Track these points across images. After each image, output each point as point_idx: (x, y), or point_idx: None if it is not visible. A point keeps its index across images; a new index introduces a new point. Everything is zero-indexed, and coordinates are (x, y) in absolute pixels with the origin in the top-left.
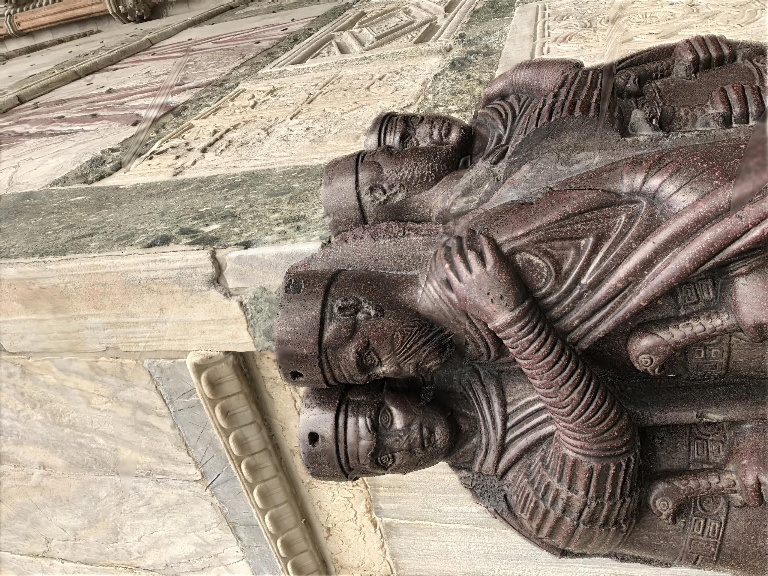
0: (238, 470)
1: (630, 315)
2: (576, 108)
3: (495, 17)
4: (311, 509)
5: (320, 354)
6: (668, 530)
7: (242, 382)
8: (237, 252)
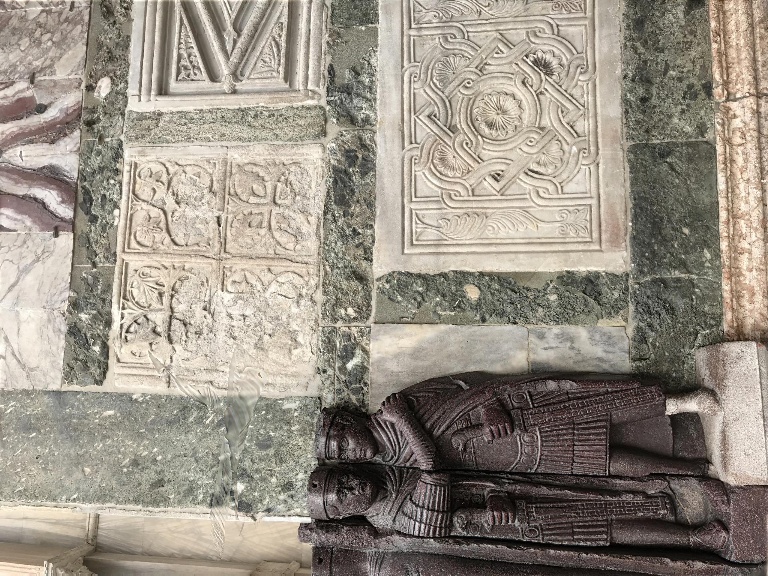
0: None
1: None
2: (430, 533)
3: (359, 18)
4: None
5: None
6: None
7: None
8: (267, 519)
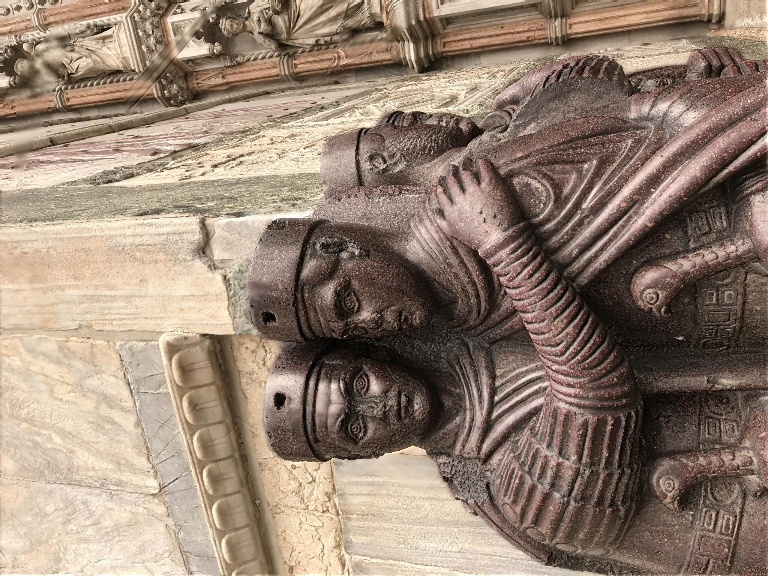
0: (199, 478)
1: (634, 239)
2: (585, 71)
3: None
4: (274, 541)
5: (296, 291)
6: (674, 524)
7: (216, 372)
8: (227, 219)
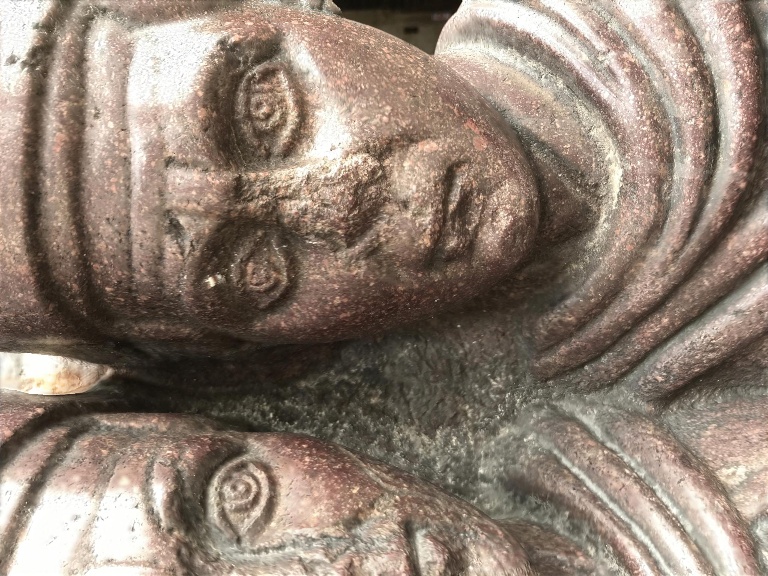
0: None
1: None
2: None
3: None
4: None
5: (56, 17)
6: None
7: None
8: None
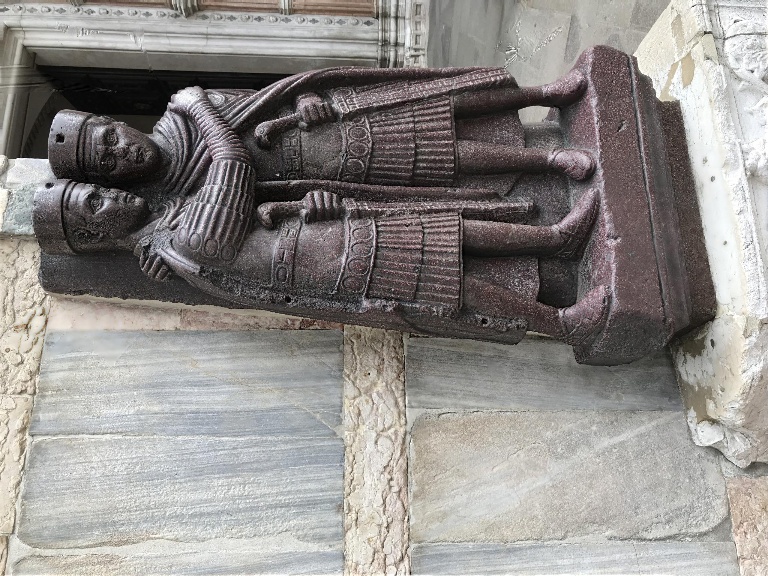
0: None
1: (256, 109)
2: None
3: None
4: None
5: (83, 125)
6: (268, 237)
7: None
8: None
